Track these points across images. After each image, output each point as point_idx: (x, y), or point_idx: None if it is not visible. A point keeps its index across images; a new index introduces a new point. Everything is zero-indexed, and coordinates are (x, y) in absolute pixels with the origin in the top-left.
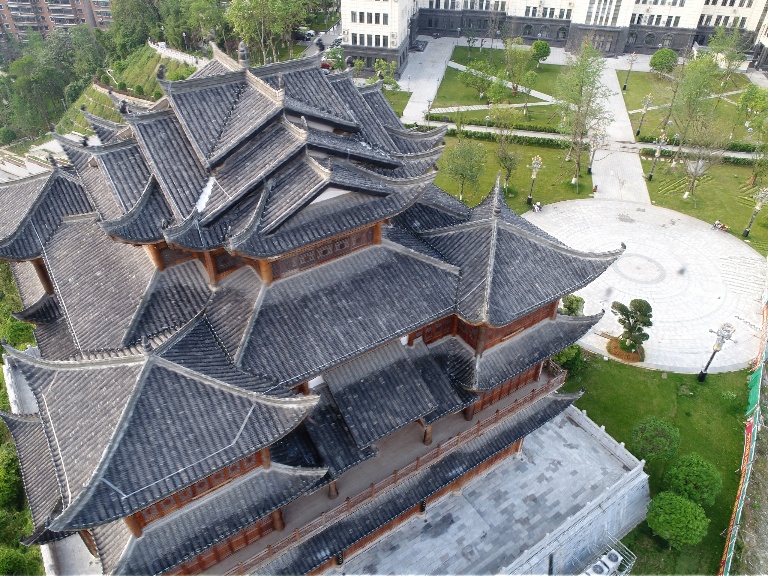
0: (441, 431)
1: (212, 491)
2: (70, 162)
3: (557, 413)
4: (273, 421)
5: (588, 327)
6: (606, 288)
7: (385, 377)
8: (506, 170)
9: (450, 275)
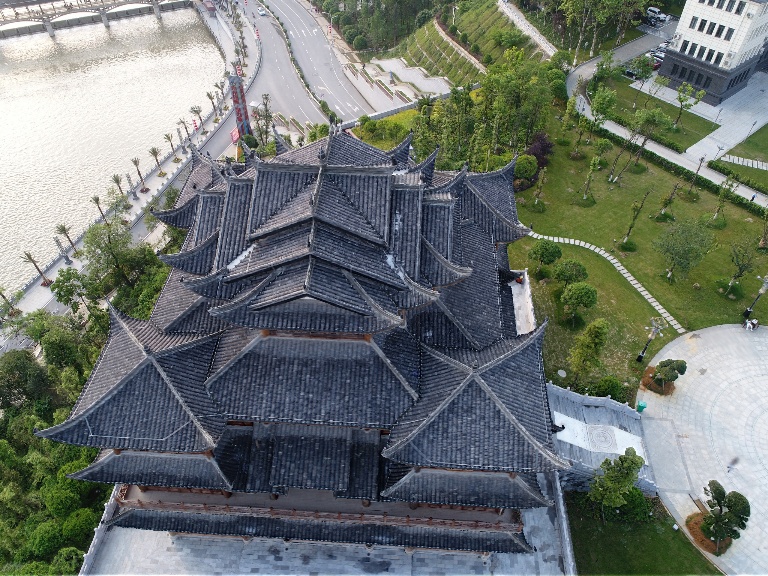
0: None
1: (169, 453)
2: (212, 180)
3: (506, 551)
4: (194, 439)
5: (537, 505)
6: (750, 456)
7: (321, 445)
8: (737, 268)
9: (408, 397)
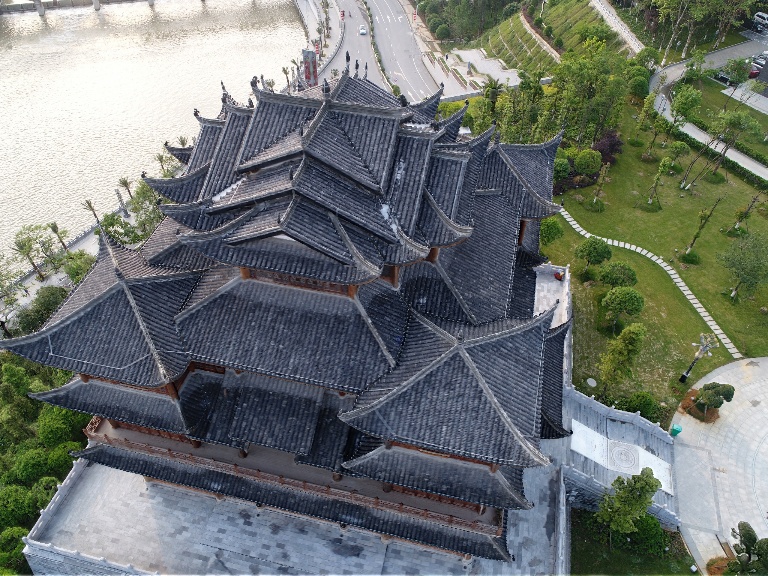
0: (356, 479)
1: (135, 388)
2: None
3: (483, 556)
4: (151, 373)
5: (515, 506)
6: None
7: (289, 403)
8: None
9: (385, 363)
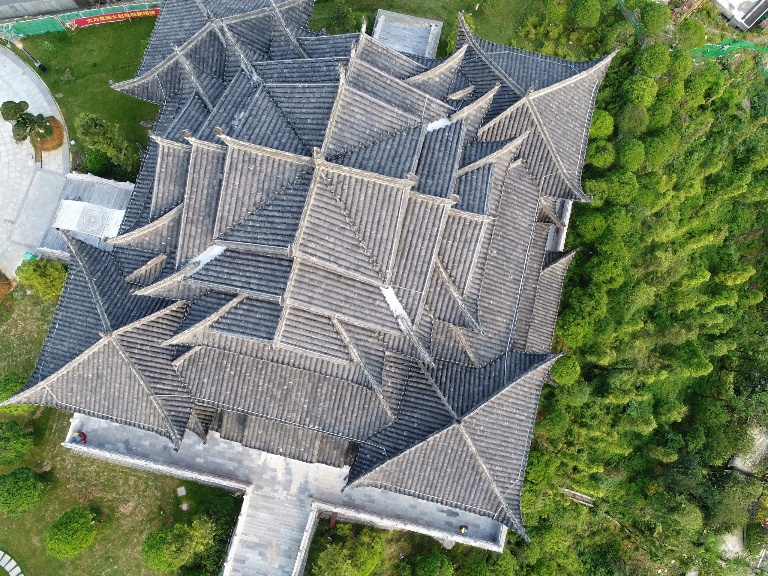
0: None
1: None
2: None
3: None
4: None
5: None
6: None
7: None
8: None
9: None
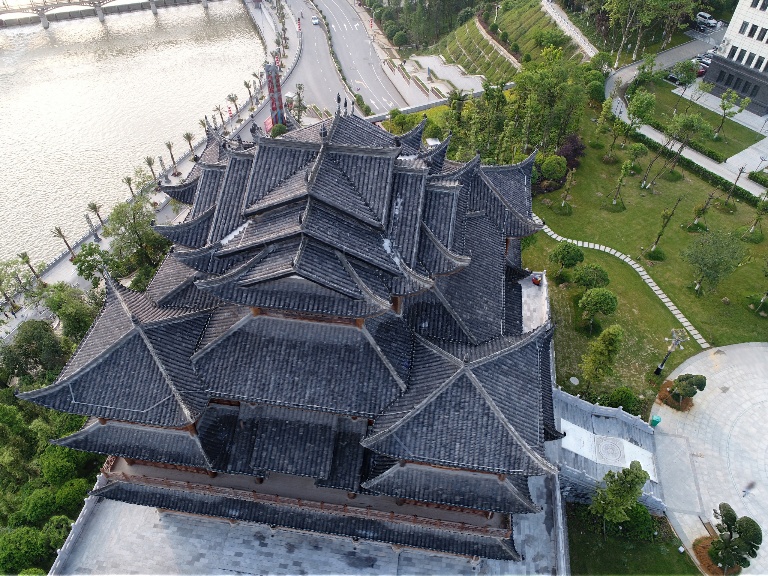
0: (370, 496)
1: (153, 427)
2: (218, 156)
3: (493, 557)
4: (175, 413)
5: (525, 510)
6: None
7: (305, 430)
8: None
9: (396, 387)
